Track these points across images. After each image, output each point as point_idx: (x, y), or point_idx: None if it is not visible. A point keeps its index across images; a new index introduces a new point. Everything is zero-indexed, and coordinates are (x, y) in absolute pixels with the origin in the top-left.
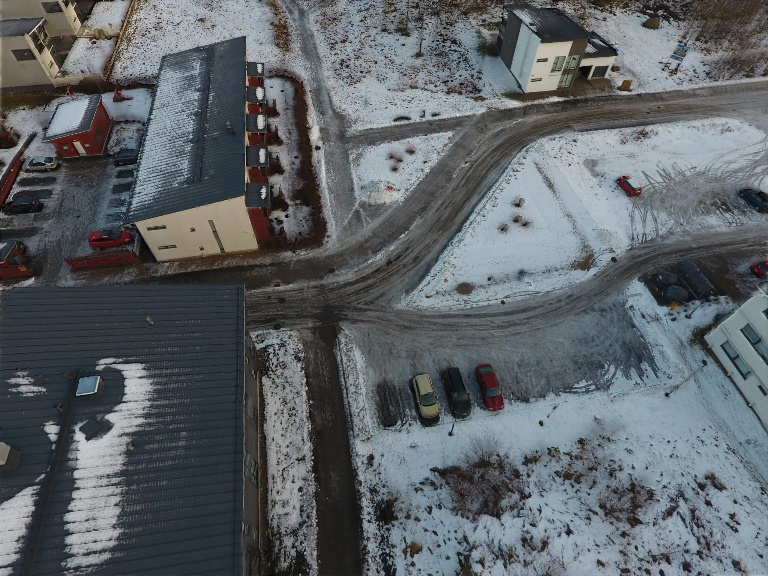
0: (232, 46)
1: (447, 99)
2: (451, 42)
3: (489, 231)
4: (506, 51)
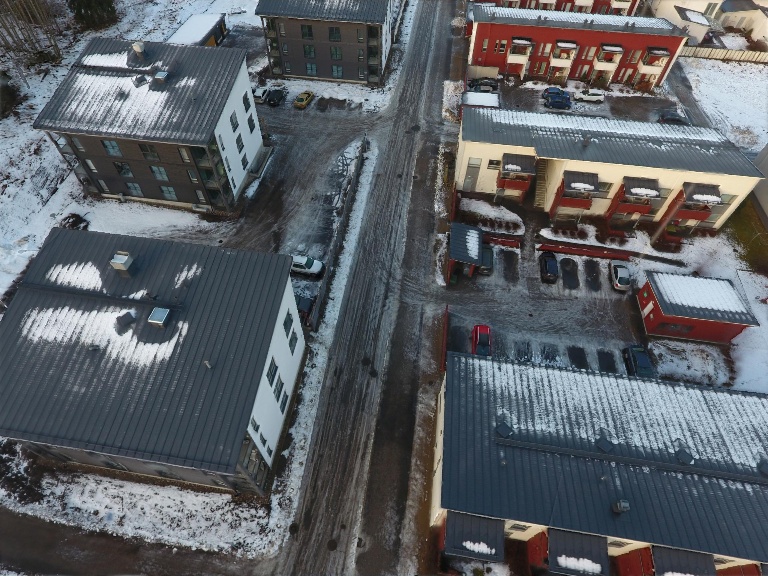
0: None
1: None
2: None
3: None
4: None
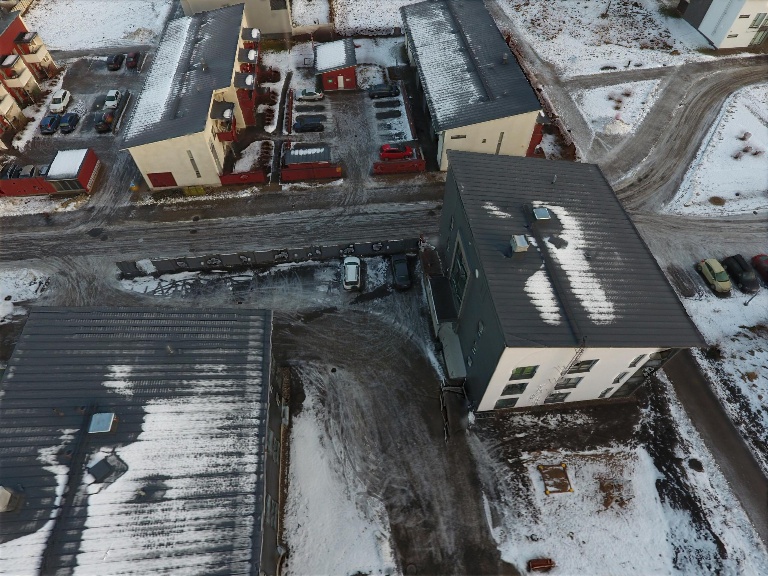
0: None
1: (644, 53)
2: (632, 5)
3: (723, 158)
4: (693, 12)
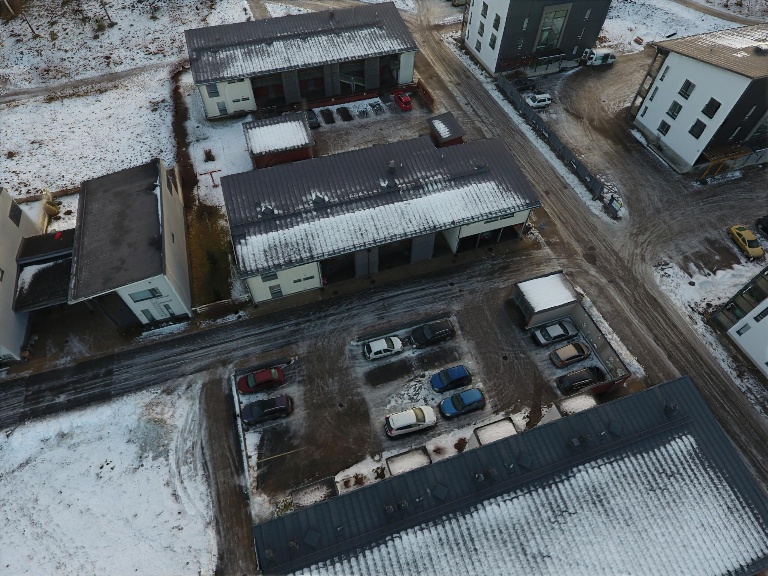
0: (202, 35)
1: (223, 7)
2: (140, 3)
3: None
4: None
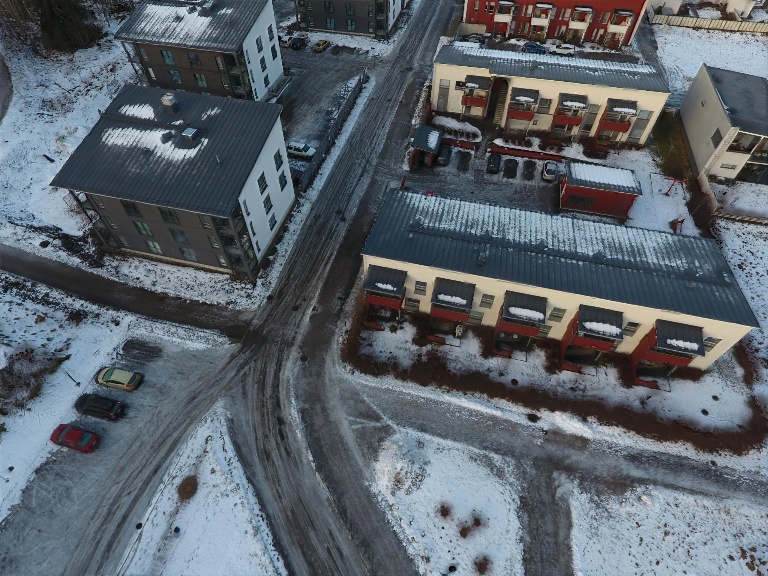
0: (722, 305)
1: None
2: None
3: None
4: None
